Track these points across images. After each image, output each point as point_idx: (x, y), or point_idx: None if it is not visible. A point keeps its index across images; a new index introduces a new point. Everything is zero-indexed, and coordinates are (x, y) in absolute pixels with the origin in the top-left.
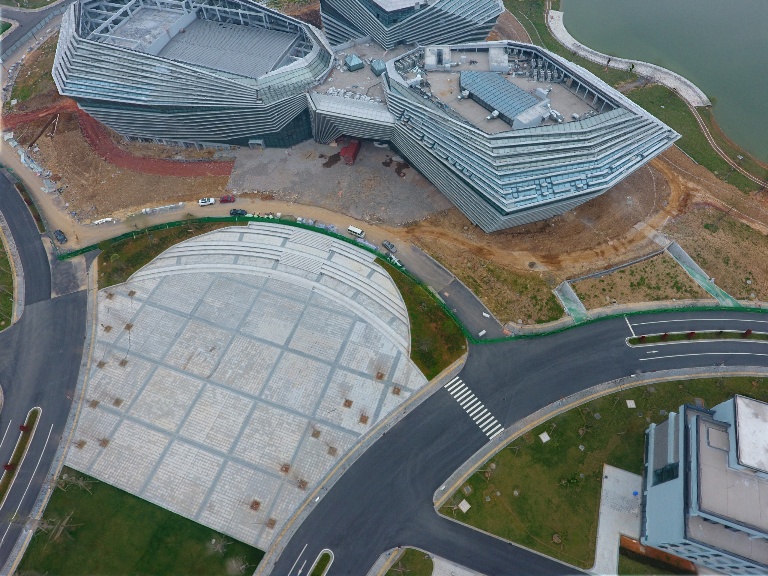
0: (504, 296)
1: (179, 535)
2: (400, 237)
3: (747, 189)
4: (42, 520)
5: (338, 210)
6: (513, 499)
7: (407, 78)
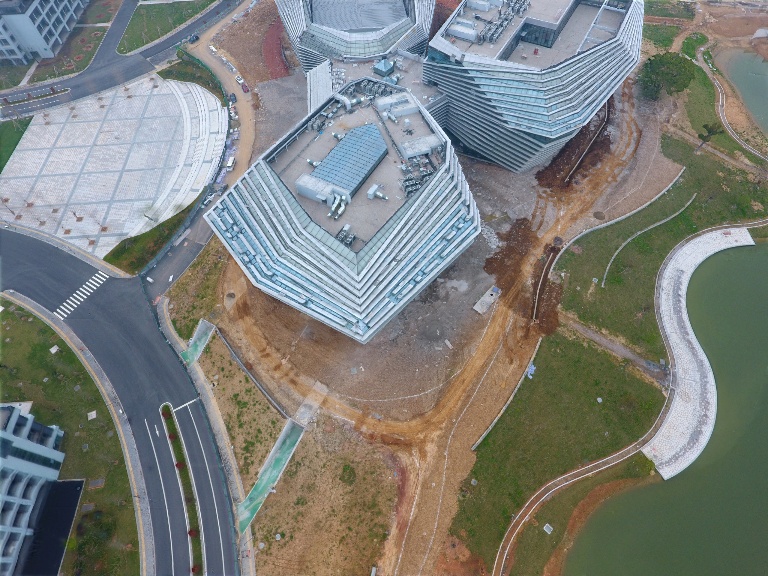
0: (190, 284)
1: None
2: None
3: (461, 532)
4: (0, 121)
5: (256, 148)
6: (3, 339)
7: (354, 97)
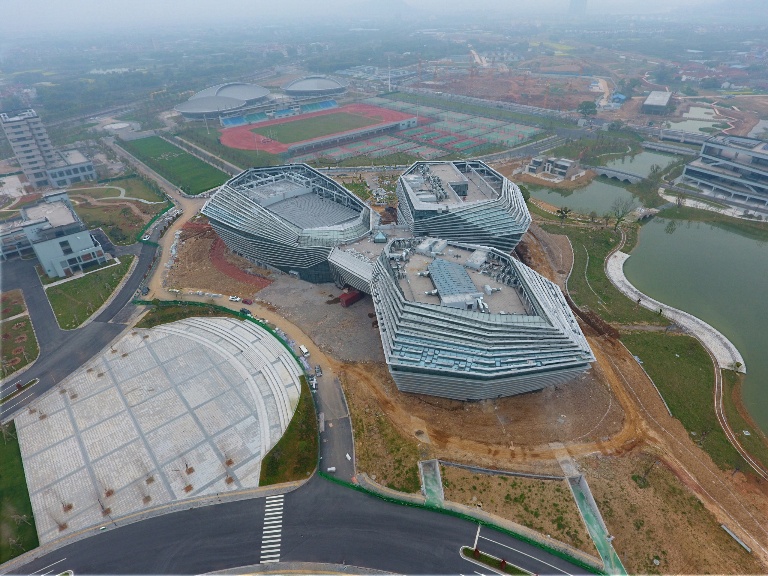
0: (374, 448)
1: (13, 499)
2: (333, 368)
3: (726, 465)
4: None
5: (308, 333)
6: None
7: (397, 253)
